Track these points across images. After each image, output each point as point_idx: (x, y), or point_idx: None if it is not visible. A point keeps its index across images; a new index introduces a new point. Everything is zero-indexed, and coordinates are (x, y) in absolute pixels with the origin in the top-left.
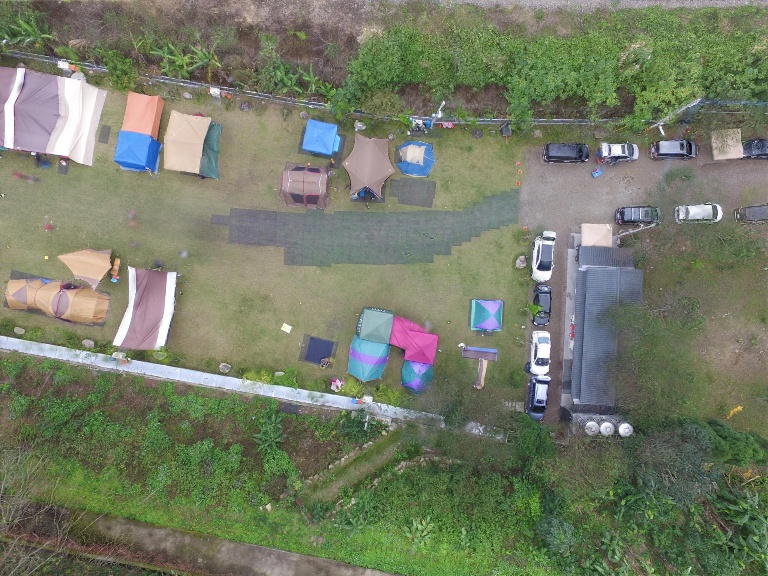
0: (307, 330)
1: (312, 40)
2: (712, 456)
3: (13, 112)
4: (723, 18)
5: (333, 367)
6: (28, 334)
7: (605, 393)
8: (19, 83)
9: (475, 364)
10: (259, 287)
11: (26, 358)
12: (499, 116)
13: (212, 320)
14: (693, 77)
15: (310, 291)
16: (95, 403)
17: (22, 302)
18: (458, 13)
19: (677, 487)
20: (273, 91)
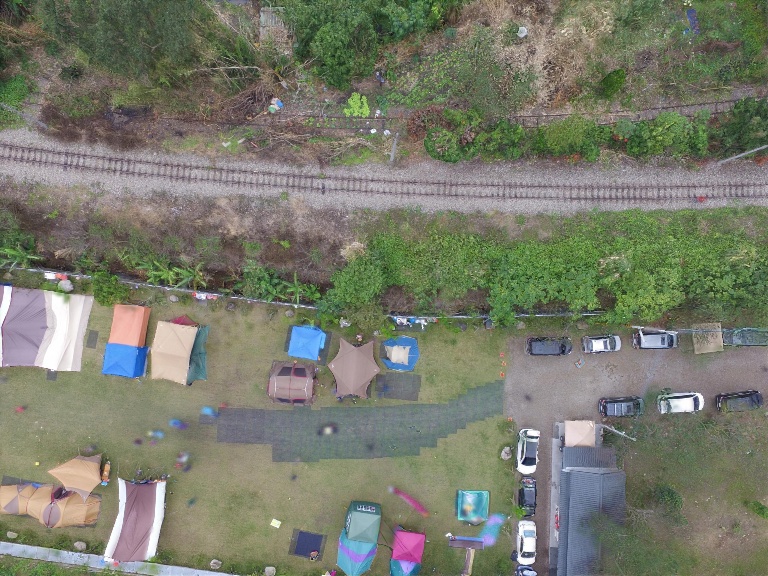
0: (296, 524)
1: (296, 248)
2: None
3: (1, 333)
4: (702, 220)
5: (323, 559)
6: (21, 541)
7: None
8: (6, 301)
9: (462, 553)
10: (248, 484)
11: (19, 563)
12: (482, 314)
13: (202, 518)
14: (672, 284)
15: (299, 486)
16: None
17: (14, 513)
18: (440, 219)
19: None
20: (258, 298)
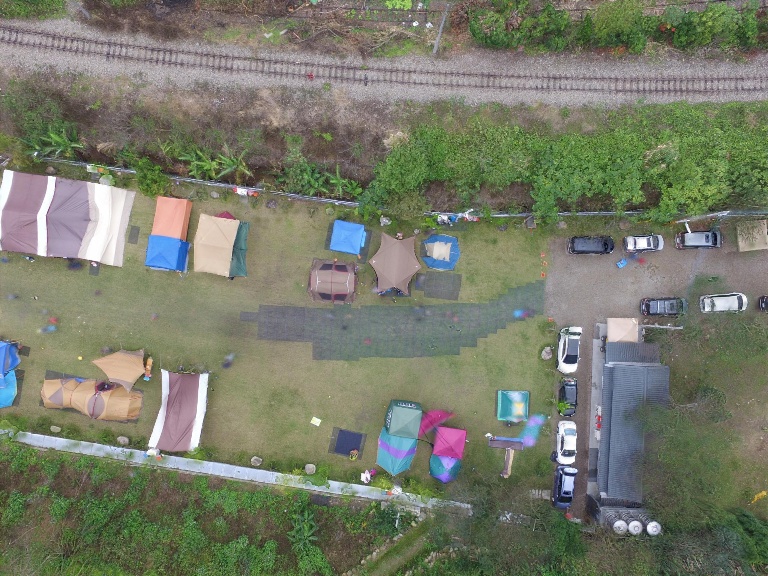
0: (336, 423)
1: (338, 141)
2: (740, 557)
3: (46, 222)
4: (749, 112)
5: (362, 458)
6: (64, 434)
7: (632, 489)
8: (50, 191)
9: (502, 453)
10: (288, 382)
11: (63, 456)
12: (524, 211)
13: (243, 415)
14: (720, 175)
15: (338, 385)
16: (132, 502)
17: (58, 404)
18: (483, 111)
19: (702, 573)
20: (300, 192)
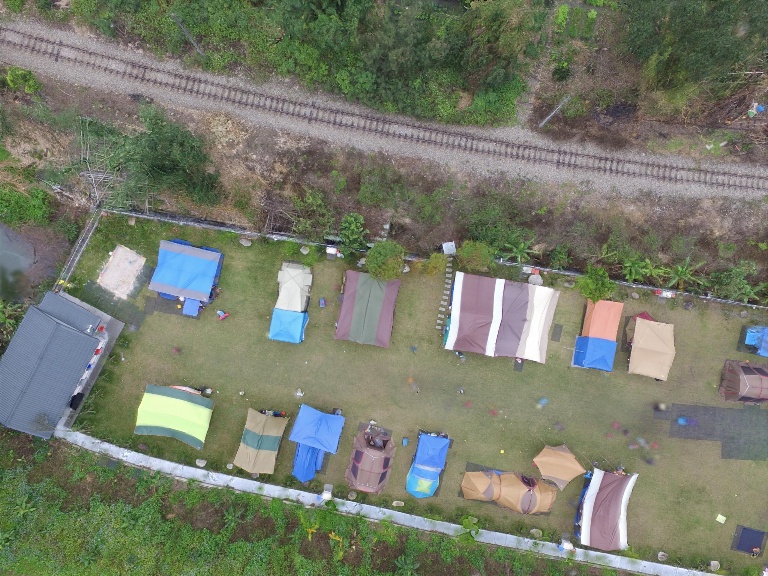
0: (740, 521)
1: None
2: None
3: (499, 324)
4: None
5: (763, 556)
6: None
7: None
8: (499, 293)
9: None
10: (697, 479)
11: (481, 547)
12: None
13: (651, 510)
14: None
15: (745, 484)
16: None
17: (489, 498)
18: None
19: None
20: None
